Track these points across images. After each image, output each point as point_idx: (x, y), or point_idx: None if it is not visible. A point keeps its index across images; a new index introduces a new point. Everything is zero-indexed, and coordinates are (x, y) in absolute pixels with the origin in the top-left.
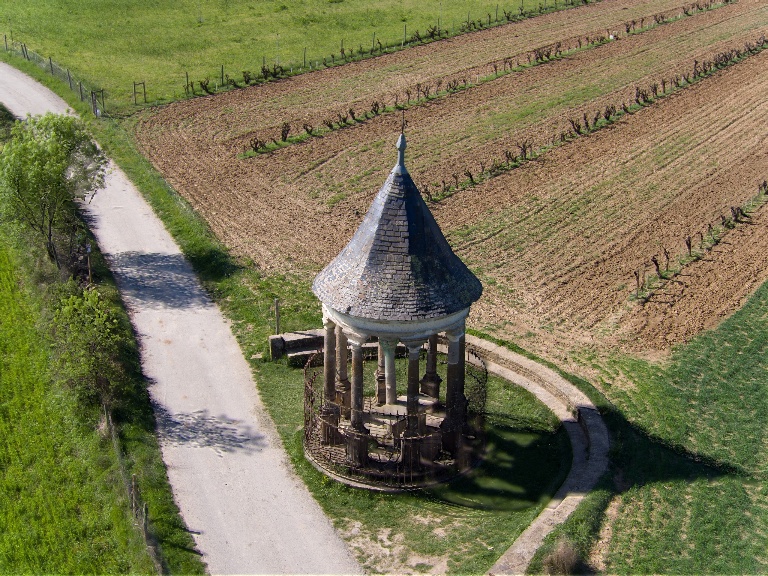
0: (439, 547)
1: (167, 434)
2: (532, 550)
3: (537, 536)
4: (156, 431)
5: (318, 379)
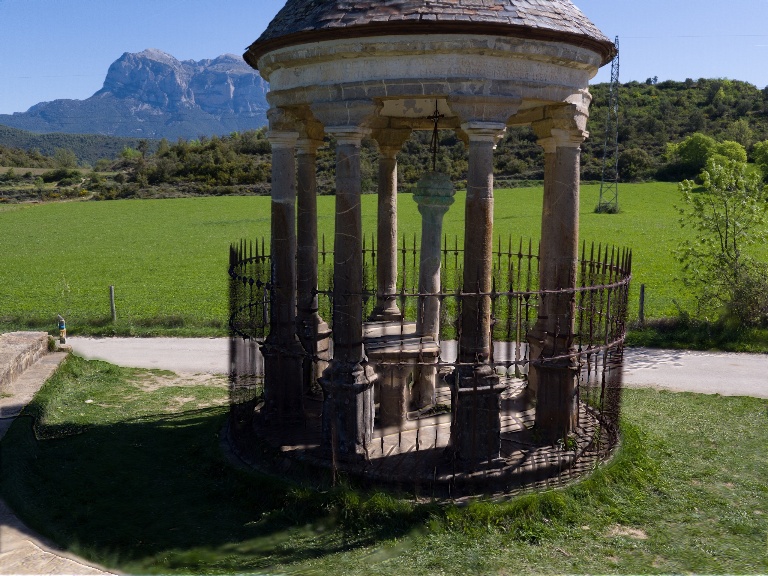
0: (167, 391)
1: (627, 350)
2: (2, 348)
3: (3, 357)
4: (640, 347)
5: (767, 443)
